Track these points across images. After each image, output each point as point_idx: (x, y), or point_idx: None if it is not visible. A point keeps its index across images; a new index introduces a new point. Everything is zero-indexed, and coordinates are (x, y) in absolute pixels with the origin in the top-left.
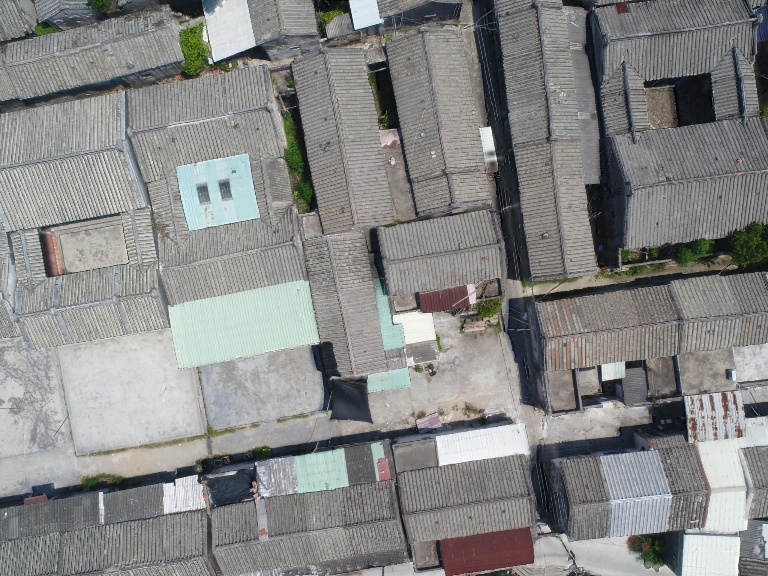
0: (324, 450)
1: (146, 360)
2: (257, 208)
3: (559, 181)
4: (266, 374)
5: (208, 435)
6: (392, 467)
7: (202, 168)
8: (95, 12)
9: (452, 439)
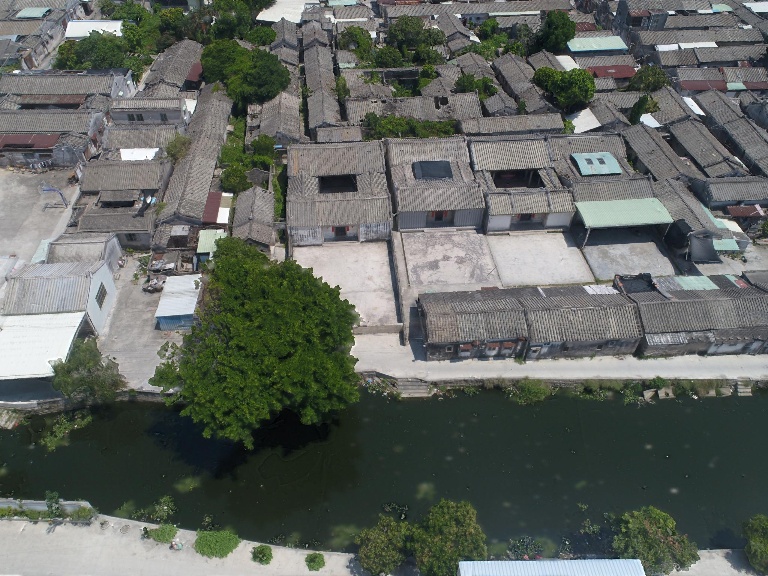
0: None
1: (547, 245)
2: (620, 169)
3: None
4: (630, 256)
5: (596, 283)
6: (747, 283)
7: (585, 154)
8: (516, 114)
9: None
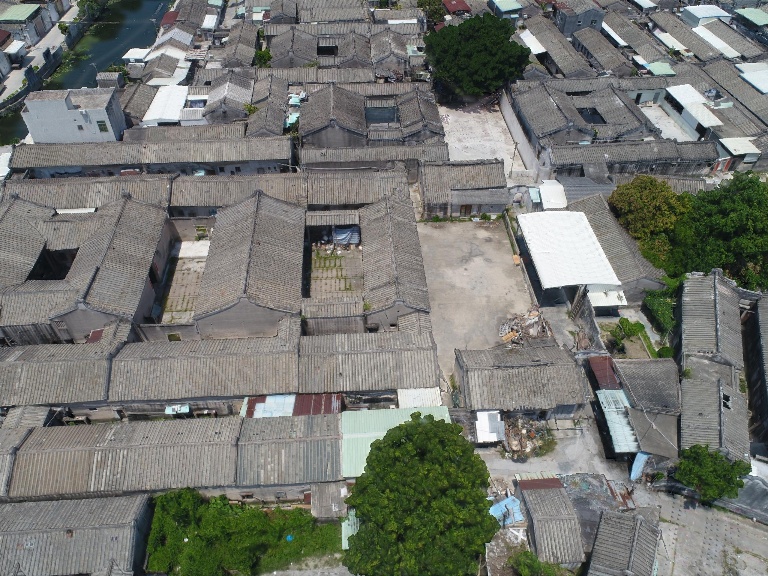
0: (222, 3)
1: None
2: None
3: (302, 26)
4: None
5: None
6: None
7: None
8: None
9: (215, 18)
